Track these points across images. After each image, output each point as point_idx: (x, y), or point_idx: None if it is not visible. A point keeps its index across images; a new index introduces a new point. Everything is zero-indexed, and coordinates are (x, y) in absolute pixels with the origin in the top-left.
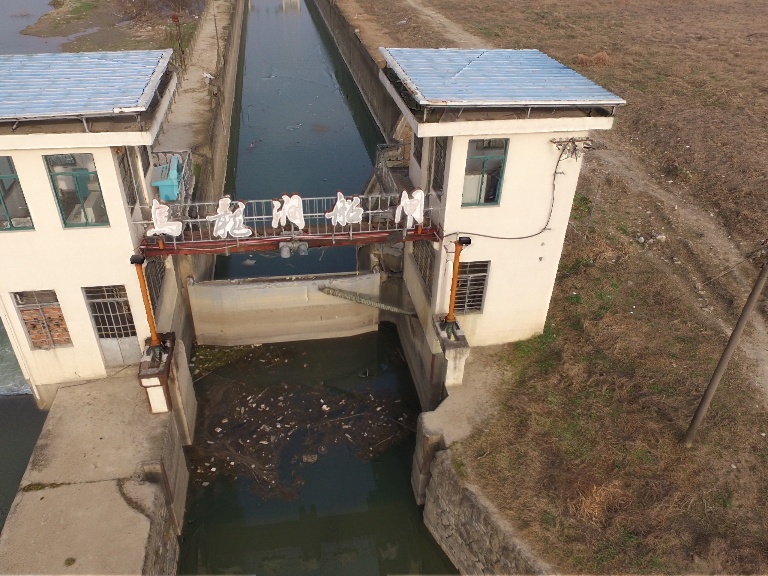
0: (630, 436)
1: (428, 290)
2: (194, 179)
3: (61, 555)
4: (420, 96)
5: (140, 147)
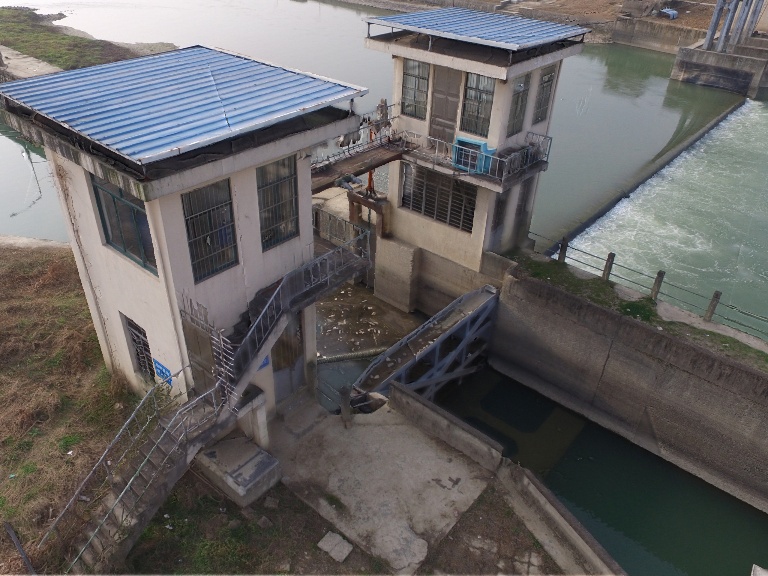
0: (15, 313)
1: None
2: (499, 189)
3: None
4: (210, 47)
5: (474, 109)
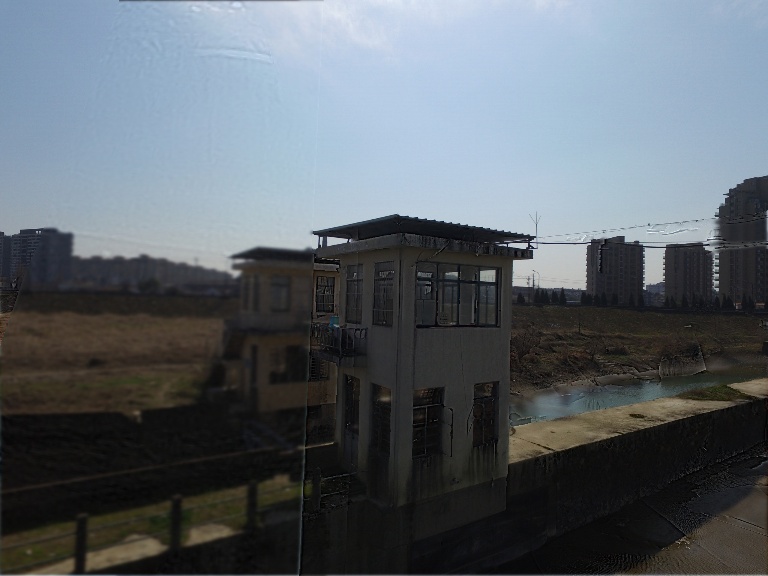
0: None
1: (313, 380)
2: None
3: (554, 434)
4: None
5: None
